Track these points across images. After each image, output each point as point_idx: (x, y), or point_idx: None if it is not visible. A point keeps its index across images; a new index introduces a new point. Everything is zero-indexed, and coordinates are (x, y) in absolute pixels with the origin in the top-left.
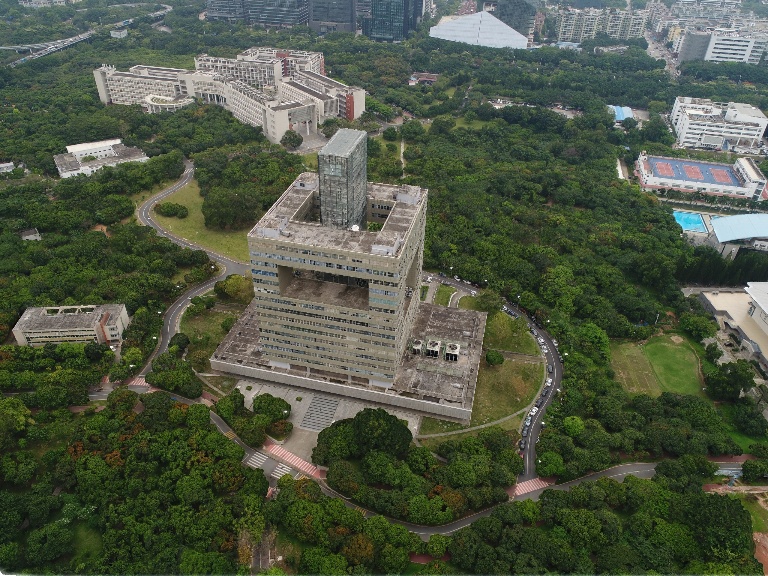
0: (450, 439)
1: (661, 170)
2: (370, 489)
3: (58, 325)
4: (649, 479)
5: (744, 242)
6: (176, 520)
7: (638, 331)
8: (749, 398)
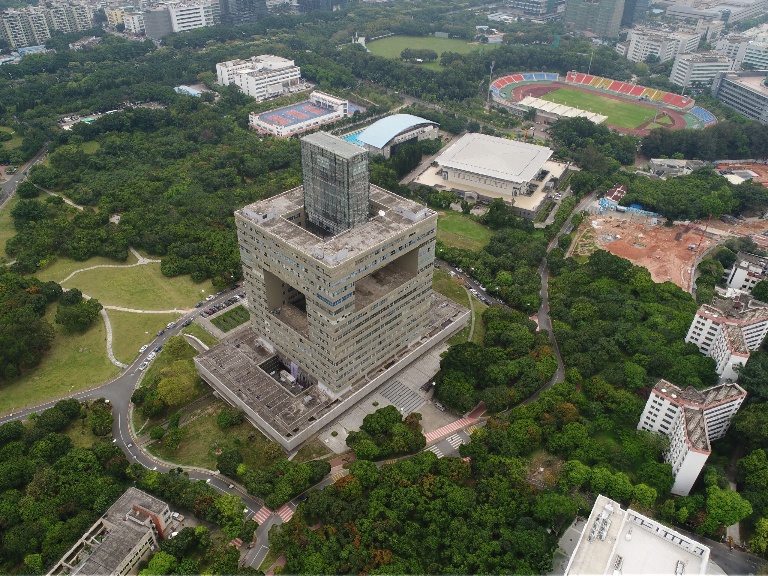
0: (476, 338)
1: (279, 121)
2: (515, 388)
3: (103, 571)
4: (548, 279)
5: (387, 143)
6: (491, 518)
7: None
8: (512, 216)
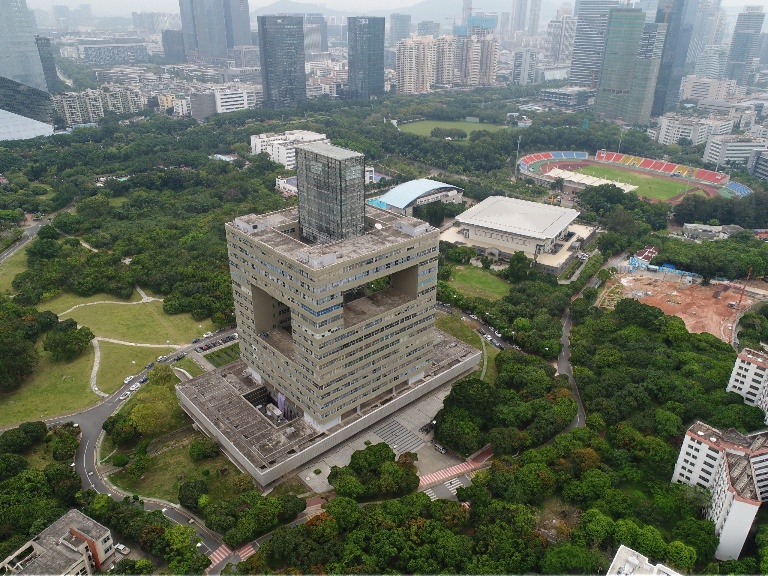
0: (487, 382)
1: None
2: (527, 431)
3: None
4: None
5: (410, 204)
6: (489, 570)
7: (447, 271)
8: (534, 271)
